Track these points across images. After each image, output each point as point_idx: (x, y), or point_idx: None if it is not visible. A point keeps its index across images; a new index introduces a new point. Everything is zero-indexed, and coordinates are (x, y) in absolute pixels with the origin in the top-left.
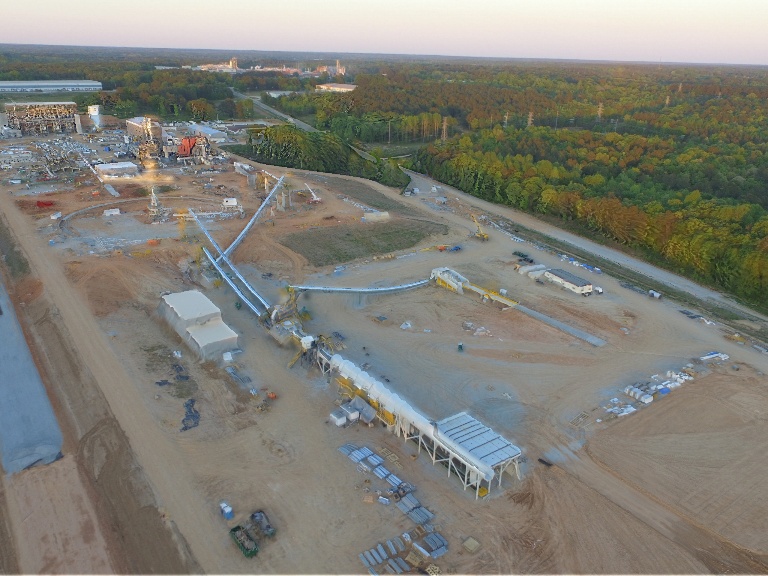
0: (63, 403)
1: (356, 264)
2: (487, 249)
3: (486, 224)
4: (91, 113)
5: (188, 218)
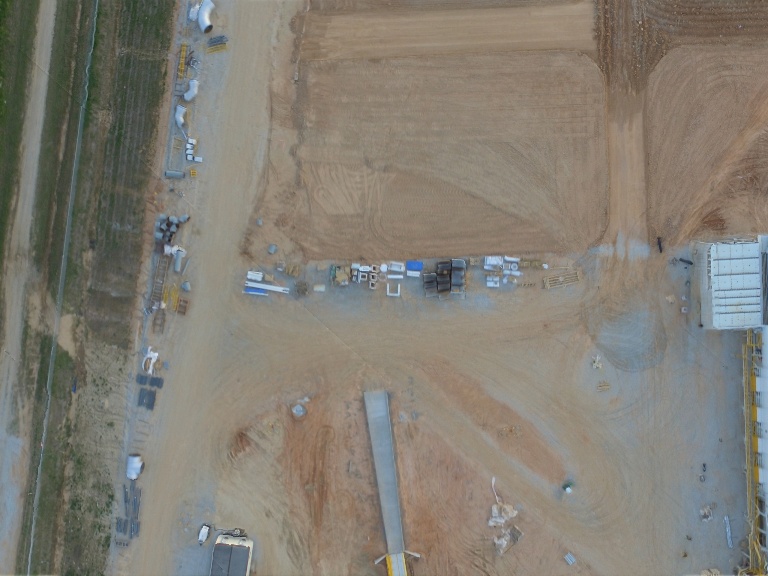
0: None
1: None
2: None
3: None
4: None
5: None
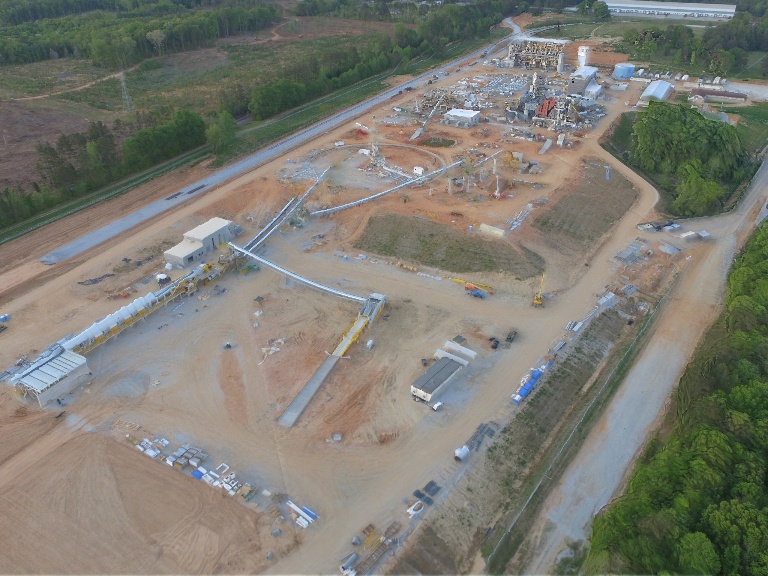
0: (102, 246)
1: (381, 260)
2: (508, 313)
3: (604, 295)
4: (579, 53)
5: (382, 173)
